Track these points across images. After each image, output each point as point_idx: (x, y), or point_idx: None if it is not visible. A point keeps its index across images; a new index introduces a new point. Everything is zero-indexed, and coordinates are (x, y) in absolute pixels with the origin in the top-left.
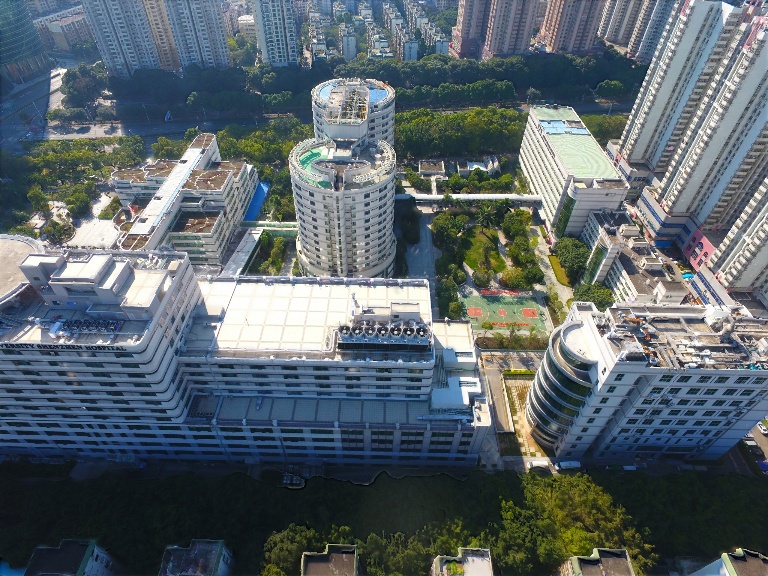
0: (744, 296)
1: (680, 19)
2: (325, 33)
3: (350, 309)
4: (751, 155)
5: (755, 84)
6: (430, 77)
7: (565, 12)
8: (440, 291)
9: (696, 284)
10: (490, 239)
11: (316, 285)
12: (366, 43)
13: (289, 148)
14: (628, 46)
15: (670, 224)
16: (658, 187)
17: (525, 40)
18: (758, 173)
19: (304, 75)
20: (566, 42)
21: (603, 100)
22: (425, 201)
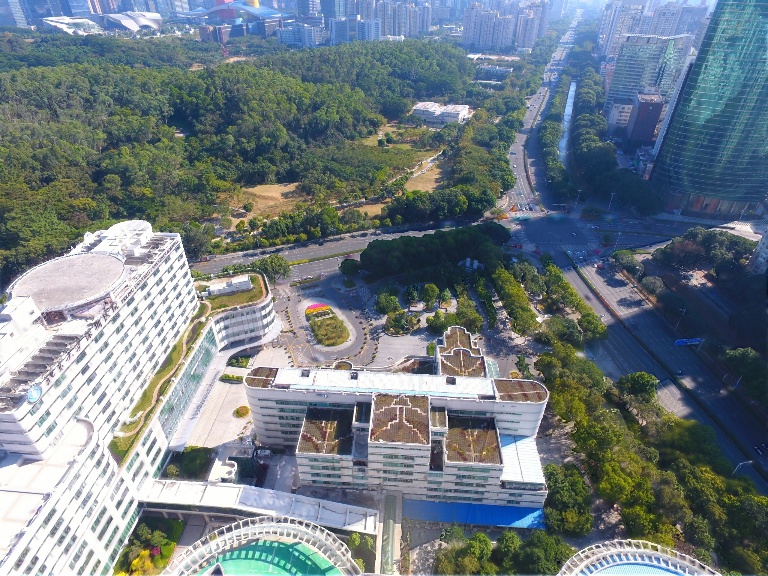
0: None
1: None
2: None
3: None
4: None
5: None
6: None
7: None
8: None
9: None
10: None
11: None
12: None
13: None
14: None
15: None
16: None
17: None
18: None
19: None
20: None
21: None
22: None
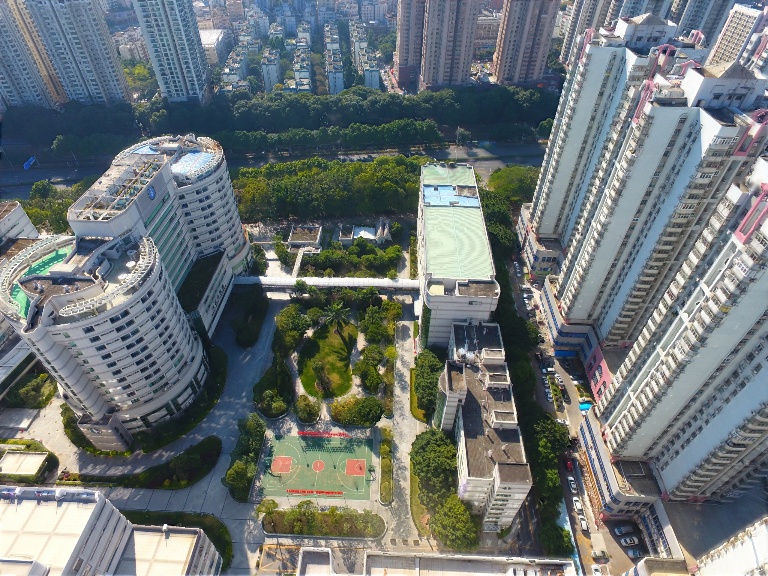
0: (636, 467)
1: (579, 68)
2: (249, 60)
3: None
4: (651, 265)
5: (649, 171)
6: (345, 114)
7: (507, 38)
8: (242, 431)
9: (584, 432)
10: (345, 342)
11: None
12: None
13: None
14: None
15: (568, 333)
16: None
17: (463, 70)
18: (667, 285)
19: (198, 113)
20: (512, 71)
21: None
22: (277, 286)
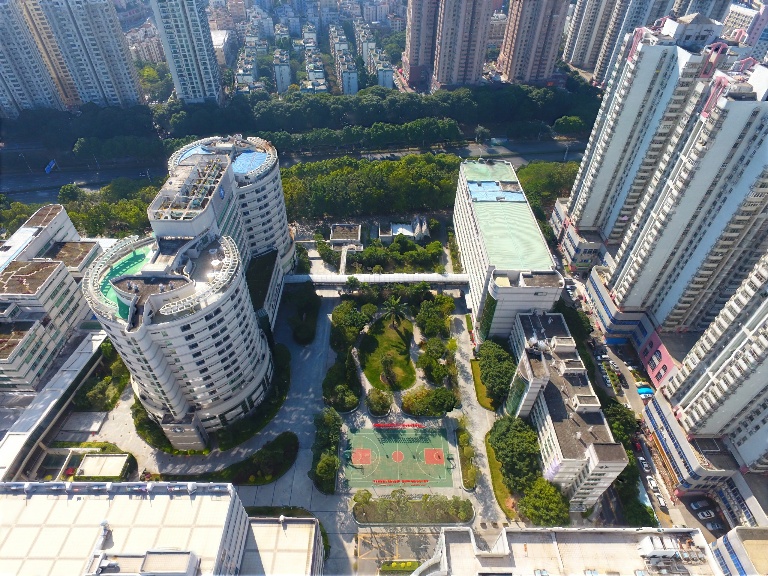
0: (711, 444)
1: (628, 65)
2: (259, 60)
3: (93, 552)
4: (716, 252)
5: (718, 163)
6: (365, 114)
7: (519, 38)
8: (319, 426)
9: (651, 414)
10: (401, 336)
11: (63, 496)
12: (305, 71)
13: None
14: (594, 72)
15: (622, 320)
16: (609, 268)
17: (476, 69)
18: (727, 271)
19: (219, 114)
20: (523, 70)
21: (562, 137)
22: (327, 283)
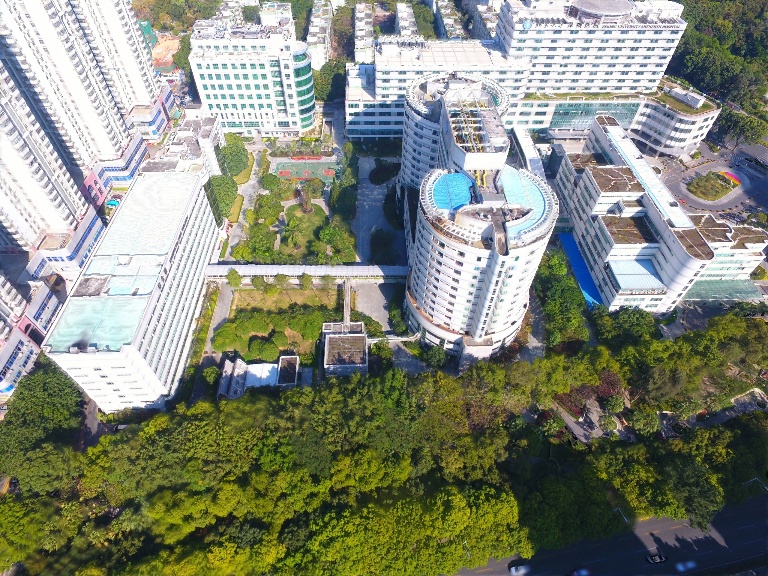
0: None
1: None
2: None
3: None
4: None
5: None
6: None
7: None
8: None
9: None
10: None
11: None
12: None
13: (601, 348)
14: None
15: None
16: None
17: None
18: None
19: None
20: None
21: None
22: None
